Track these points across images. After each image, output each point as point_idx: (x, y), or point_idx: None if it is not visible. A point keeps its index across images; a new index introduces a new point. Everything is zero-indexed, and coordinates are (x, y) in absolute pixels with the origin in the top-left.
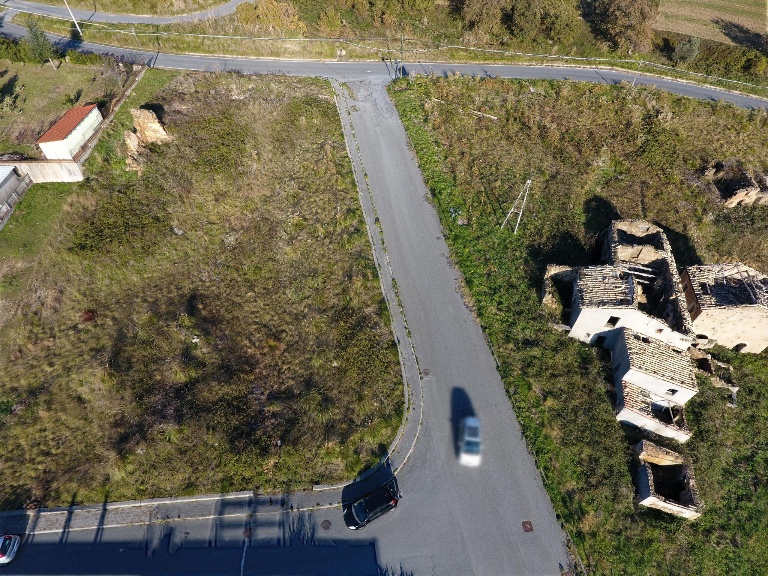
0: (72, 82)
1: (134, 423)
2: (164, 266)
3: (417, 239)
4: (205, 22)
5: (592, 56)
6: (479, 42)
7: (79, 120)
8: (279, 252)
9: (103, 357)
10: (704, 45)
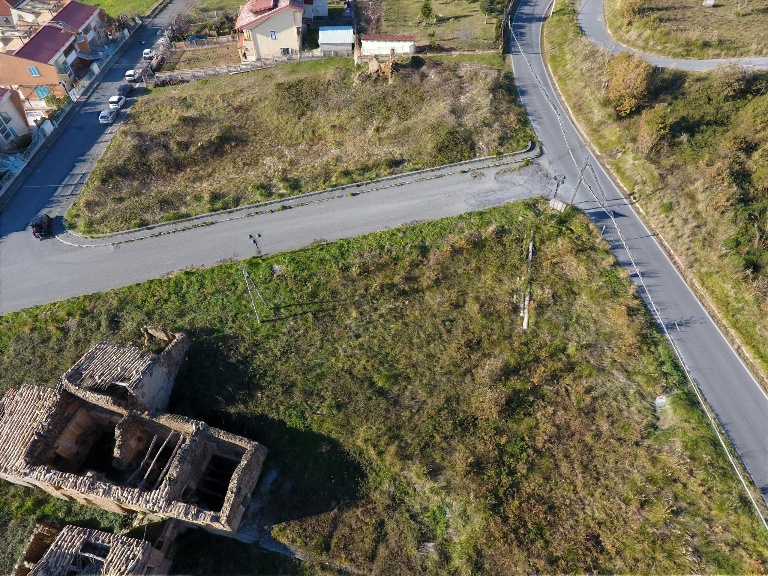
0: None
1: None
2: None
3: None
4: None
5: None
6: None
7: (388, 39)
8: None
9: None
10: None
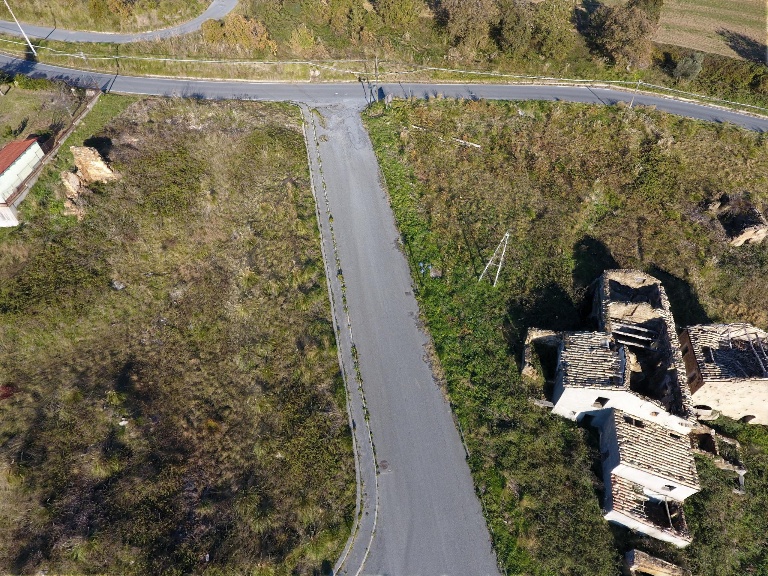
0: (19, 110)
1: (40, 533)
2: (100, 327)
3: (383, 295)
4: (167, 41)
5: (587, 73)
6: (464, 59)
7: (14, 158)
8: (230, 308)
9: (14, 447)
10: (708, 60)
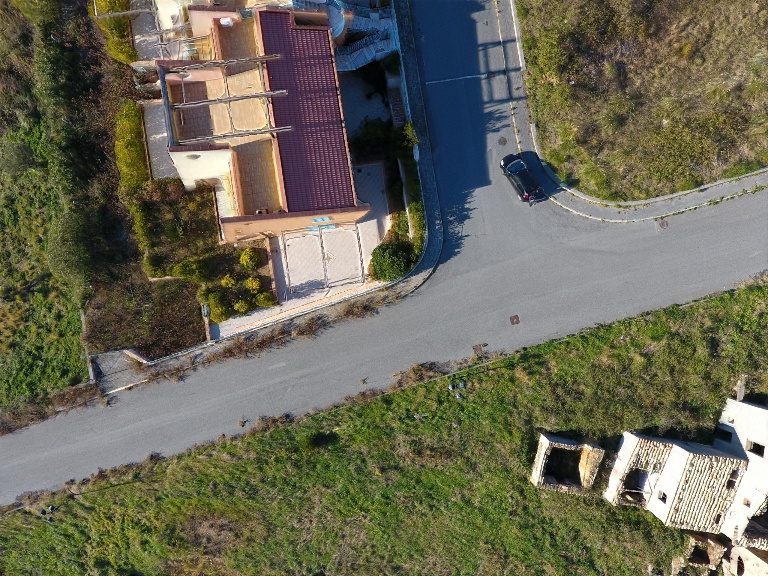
0: None
1: None
2: None
3: None
4: None
5: None
6: None
7: None
8: None
9: None
10: None
